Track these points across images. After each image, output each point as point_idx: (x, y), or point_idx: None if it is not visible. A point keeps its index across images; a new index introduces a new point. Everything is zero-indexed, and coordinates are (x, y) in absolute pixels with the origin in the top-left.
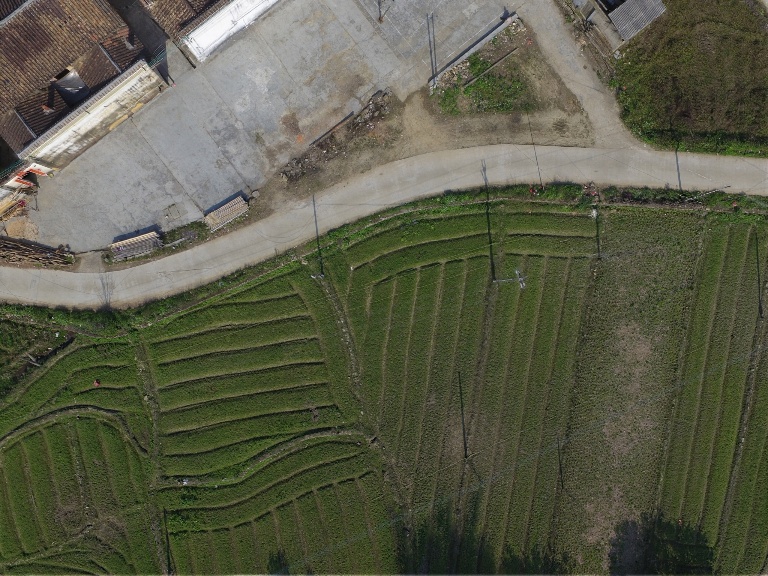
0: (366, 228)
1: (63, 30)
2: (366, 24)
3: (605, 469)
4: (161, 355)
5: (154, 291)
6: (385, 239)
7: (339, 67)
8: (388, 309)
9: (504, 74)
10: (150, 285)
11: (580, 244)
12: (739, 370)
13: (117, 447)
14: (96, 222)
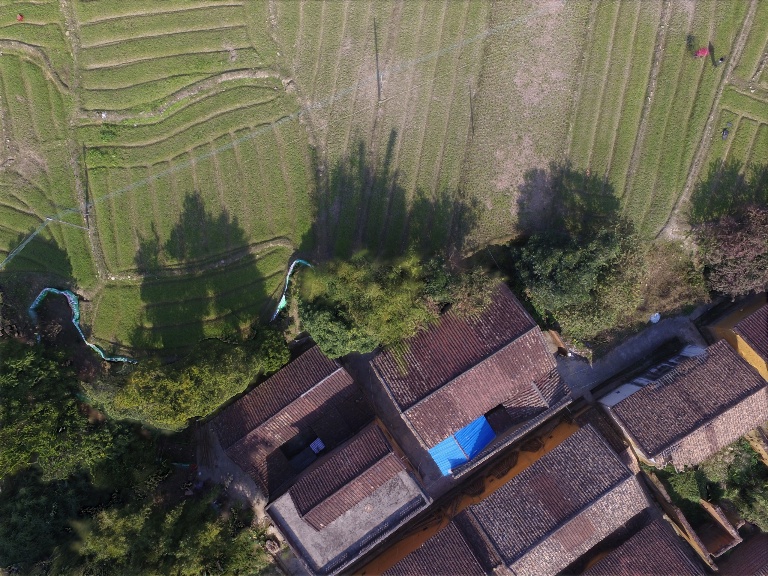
0: None
1: None
2: None
3: (515, 118)
4: None
5: None
6: None
7: None
8: None
9: None
10: None
11: None
12: (649, 26)
13: (39, 83)
14: None
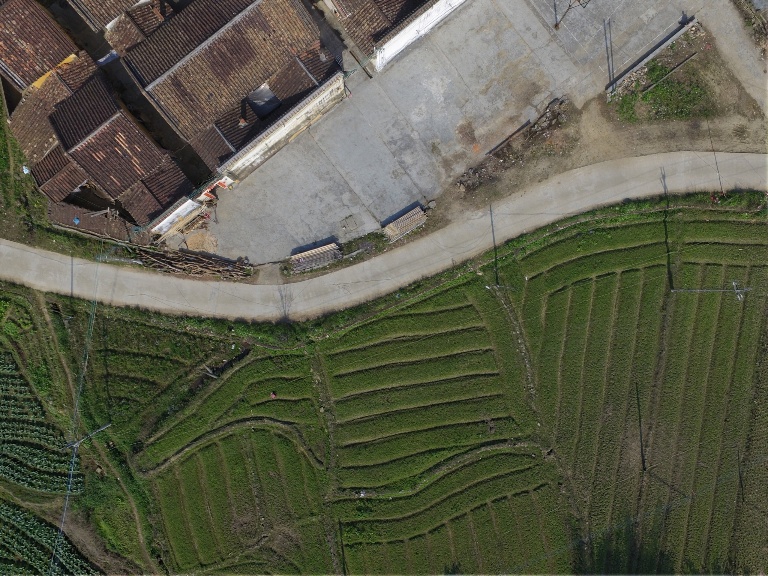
0: (542, 238)
1: (266, 43)
2: (542, 31)
3: None
4: (337, 367)
5: (332, 303)
6: (561, 249)
7: (515, 75)
8: (564, 319)
9: (683, 80)
10: (328, 297)
11: (760, 252)
12: None
13: (292, 459)
14: (274, 234)
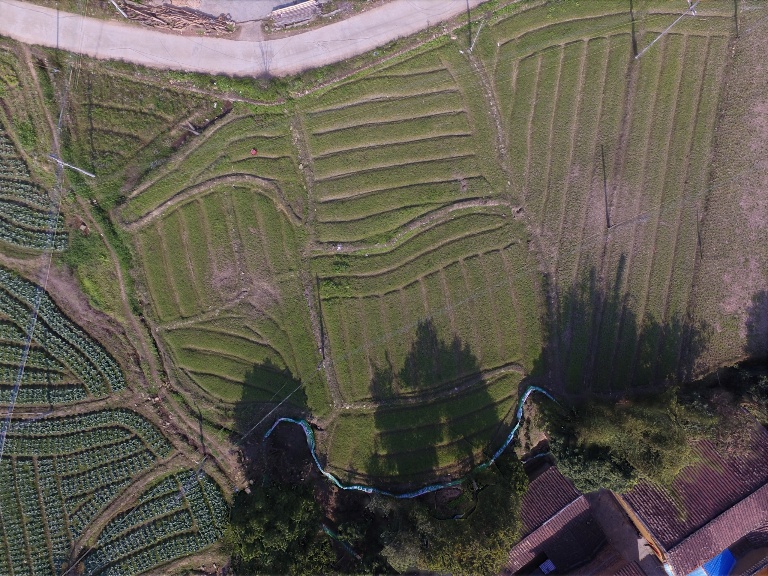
0: (514, 3)
1: None
2: None
3: (742, 241)
4: (316, 124)
5: (311, 60)
6: (532, 15)
7: None
8: (534, 84)
9: None
10: (307, 54)
11: (719, 23)
12: None
13: (272, 215)
14: None
